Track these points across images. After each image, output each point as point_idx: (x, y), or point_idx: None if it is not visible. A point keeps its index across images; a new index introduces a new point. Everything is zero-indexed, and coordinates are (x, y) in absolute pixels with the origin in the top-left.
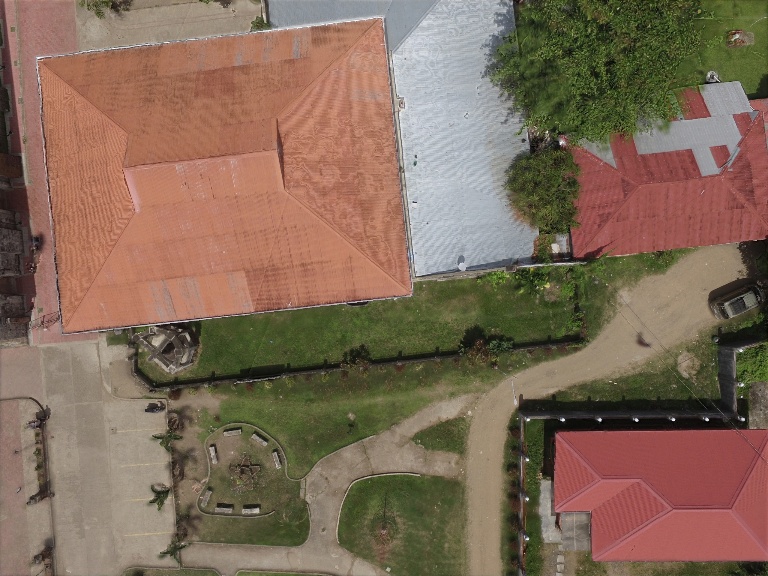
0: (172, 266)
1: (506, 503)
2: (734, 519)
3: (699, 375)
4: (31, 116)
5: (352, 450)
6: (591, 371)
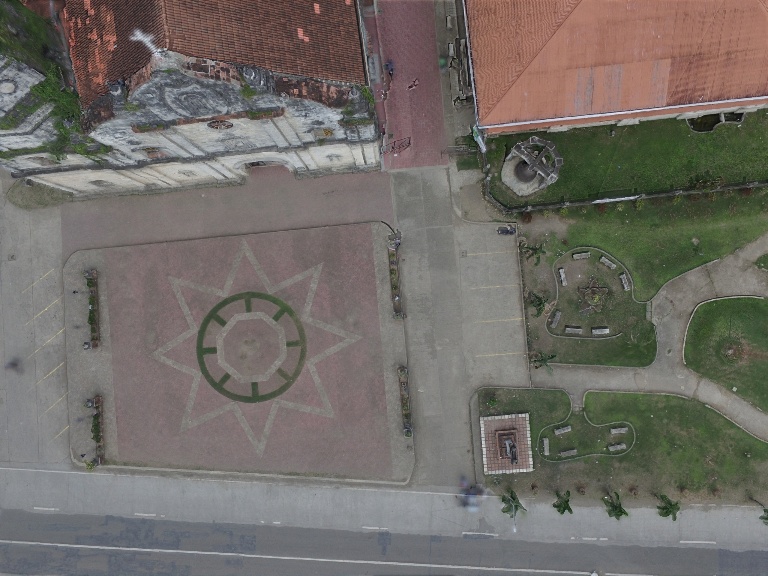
0: (605, 52)
1: None
2: None
3: None
4: None
5: (696, 274)
6: None
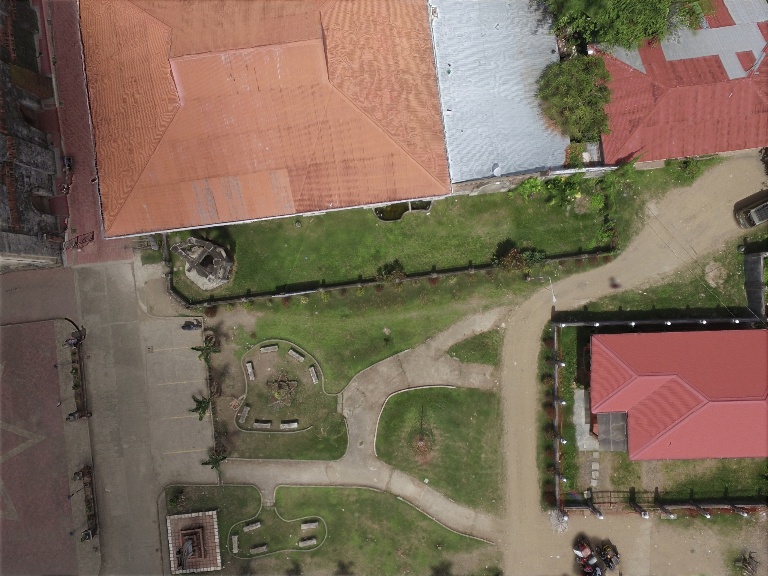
0: (216, 164)
1: (541, 413)
2: (767, 411)
3: (726, 284)
4: (61, 38)
5: (388, 364)
6: (621, 282)
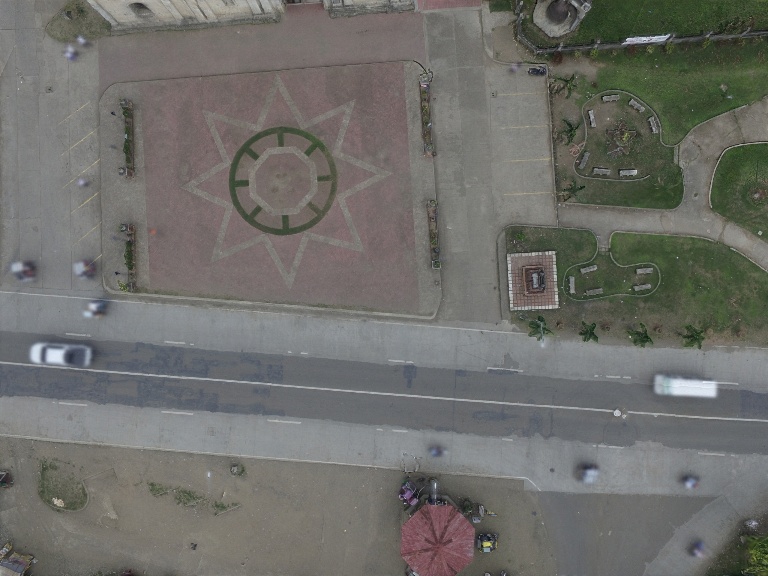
0: None
1: None
2: None
3: None
4: None
5: (724, 119)
6: None
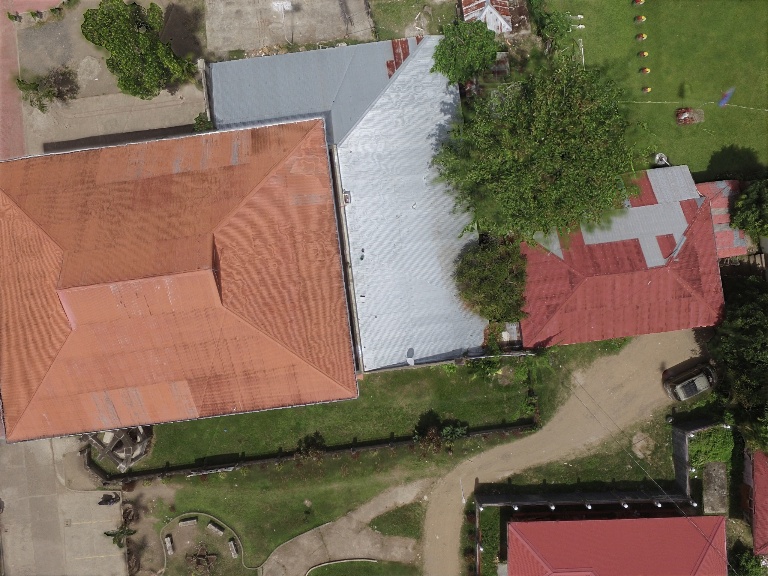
0: (113, 378)
1: None
2: None
3: (653, 455)
4: None
5: (309, 537)
6: (546, 453)
